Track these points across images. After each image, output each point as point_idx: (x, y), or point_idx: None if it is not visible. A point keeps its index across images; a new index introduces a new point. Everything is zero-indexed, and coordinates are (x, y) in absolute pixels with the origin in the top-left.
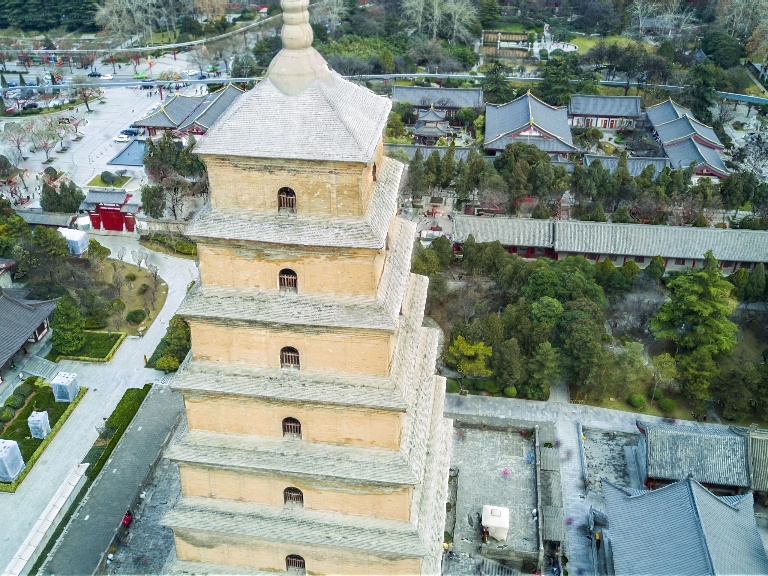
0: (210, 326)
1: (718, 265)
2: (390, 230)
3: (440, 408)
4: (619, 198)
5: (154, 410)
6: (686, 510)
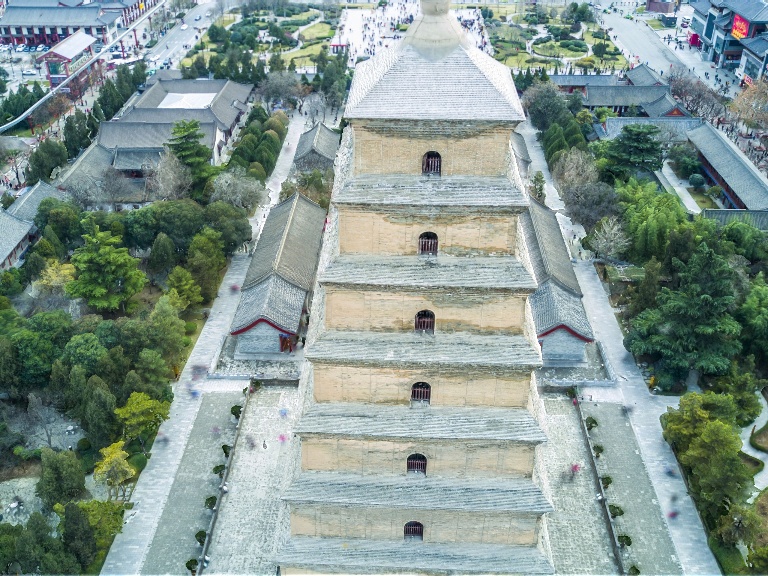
0: None
1: (8, 260)
2: None
3: None
4: None
5: None
6: None
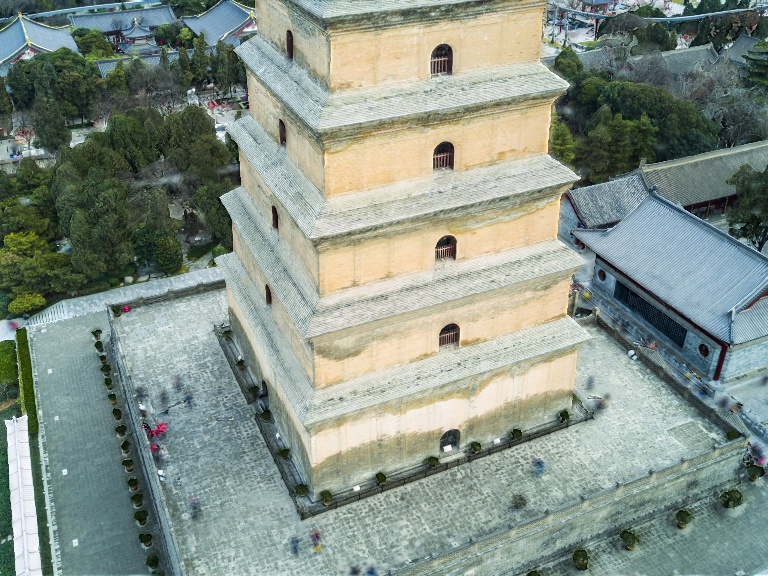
0: (355, 34)
1: None
2: None
3: None
4: None
5: (51, 349)
6: (667, 215)
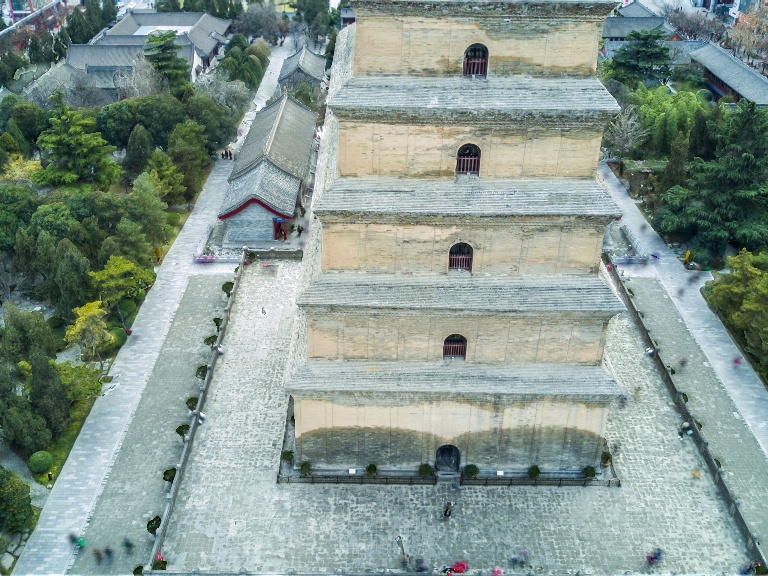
0: None
1: None
2: None
3: None
4: None
5: None
6: None
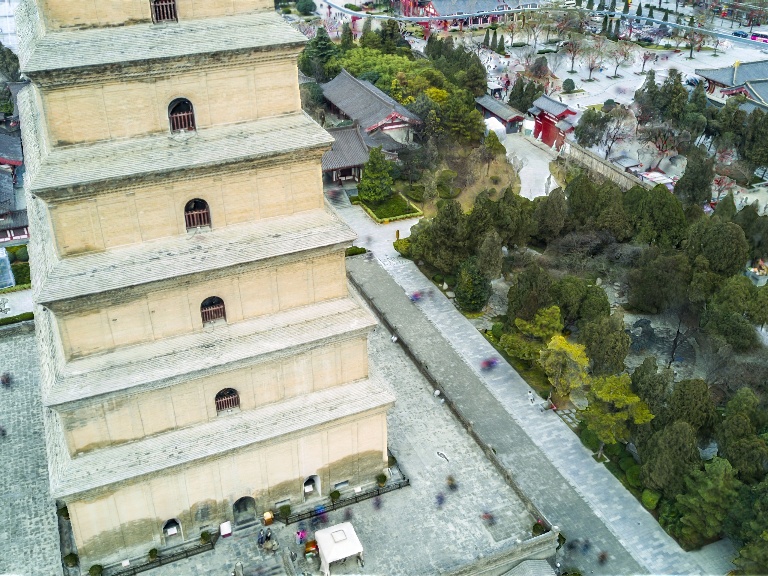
0: None
1: None
2: (202, 2)
3: (308, 334)
4: None
5: None
6: None
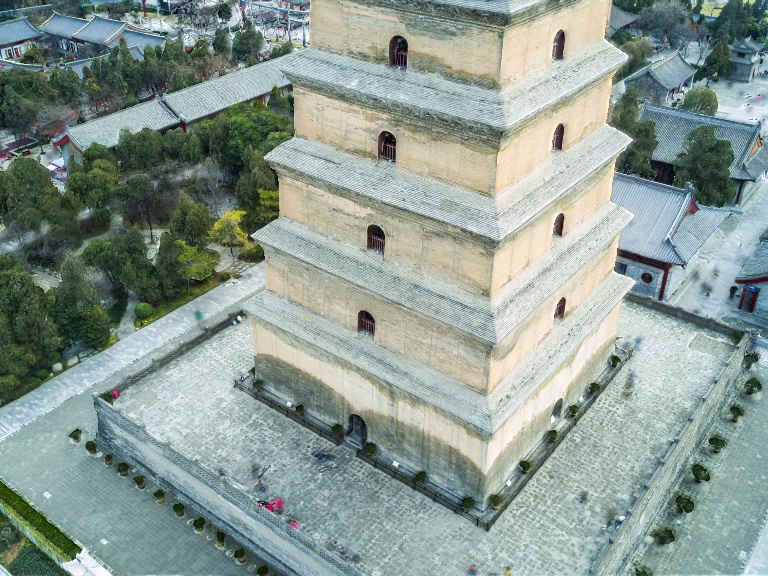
0: (517, 28)
1: None
2: None
3: None
4: (139, 87)
5: (27, 471)
6: None
